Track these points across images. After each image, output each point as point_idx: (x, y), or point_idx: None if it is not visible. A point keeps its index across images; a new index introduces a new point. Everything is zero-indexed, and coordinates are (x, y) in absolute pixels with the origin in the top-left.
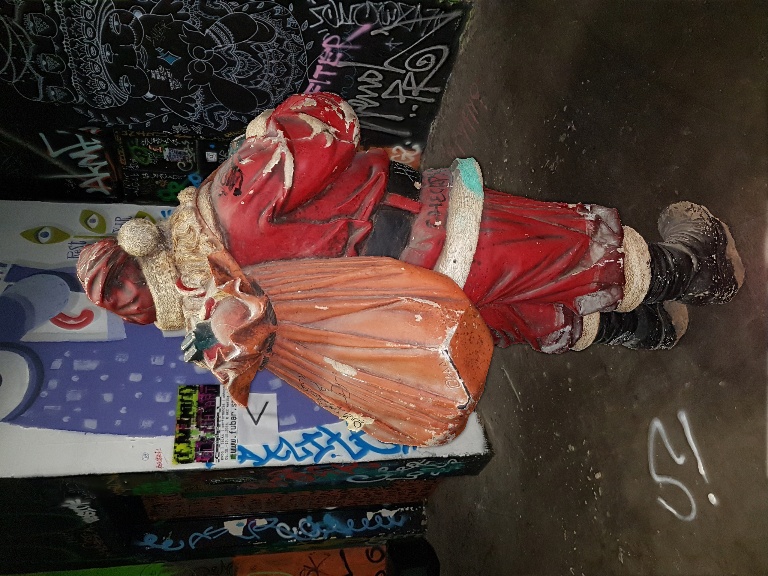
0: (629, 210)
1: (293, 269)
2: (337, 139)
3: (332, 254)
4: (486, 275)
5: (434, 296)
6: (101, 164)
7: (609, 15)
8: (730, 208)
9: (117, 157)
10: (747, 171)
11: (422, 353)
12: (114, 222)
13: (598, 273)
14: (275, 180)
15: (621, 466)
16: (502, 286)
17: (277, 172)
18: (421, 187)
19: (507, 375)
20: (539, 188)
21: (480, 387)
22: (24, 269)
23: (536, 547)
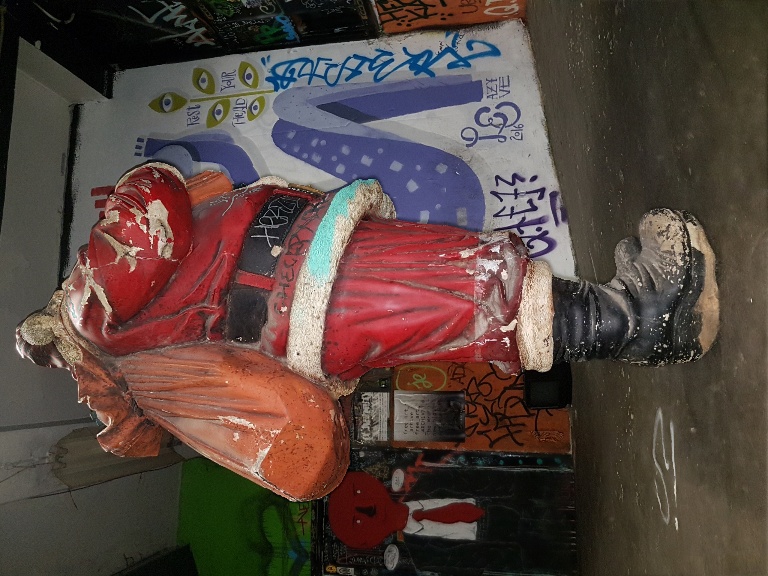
0: (658, 158)
1: (146, 369)
2: (142, 258)
3: (192, 338)
4: (348, 352)
5: (254, 412)
6: (193, 22)
7: None
8: (724, 235)
9: (203, 13)
10: (741, 199)
11: (240, 469)
12: (221, 79)
13: (479, 350)
14: (96, 307)
15: (643, 425)
16: (375, 355)
17: (94, 302)
18: (281, 251)
19: (592, 261)
20: (604, 64)
21: (314, 484)
22: (156, 141)
23: (607, 431)
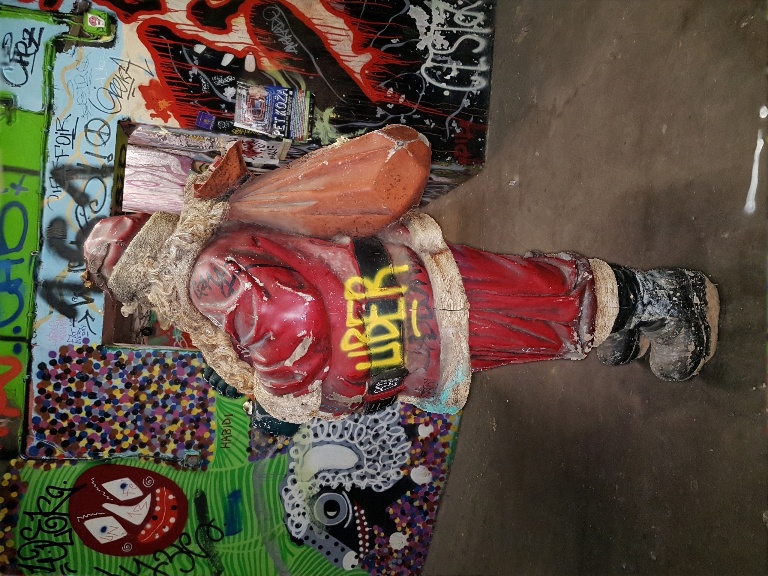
0: (664, 439)
1: None
2: None
3: None
4: None
5: None
6: None
7: (565, 575)
8: None
9: None
10: None
11: None
12: None
13: None
14: None
15: None
16: None
17: None
18: None
19: None
20: None
21: None
22: None
23: None
